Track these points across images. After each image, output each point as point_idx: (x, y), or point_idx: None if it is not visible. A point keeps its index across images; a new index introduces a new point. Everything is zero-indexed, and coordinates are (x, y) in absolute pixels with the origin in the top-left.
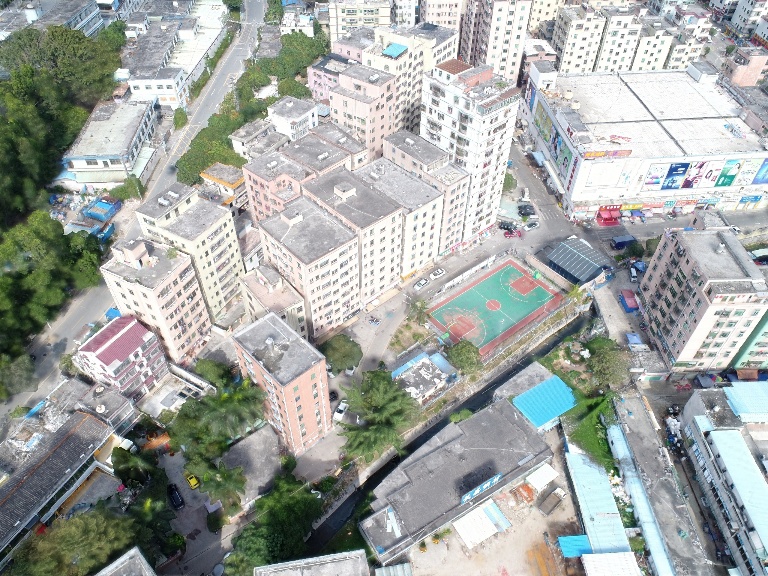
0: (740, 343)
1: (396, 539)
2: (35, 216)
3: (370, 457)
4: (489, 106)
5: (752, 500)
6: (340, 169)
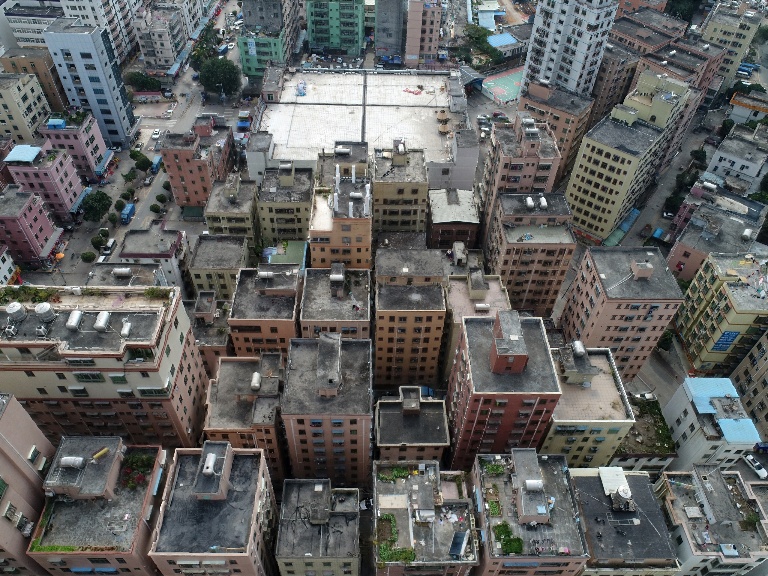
0: None
1: None
2: None
3: None
4: None
5: None
6: (655, 46)
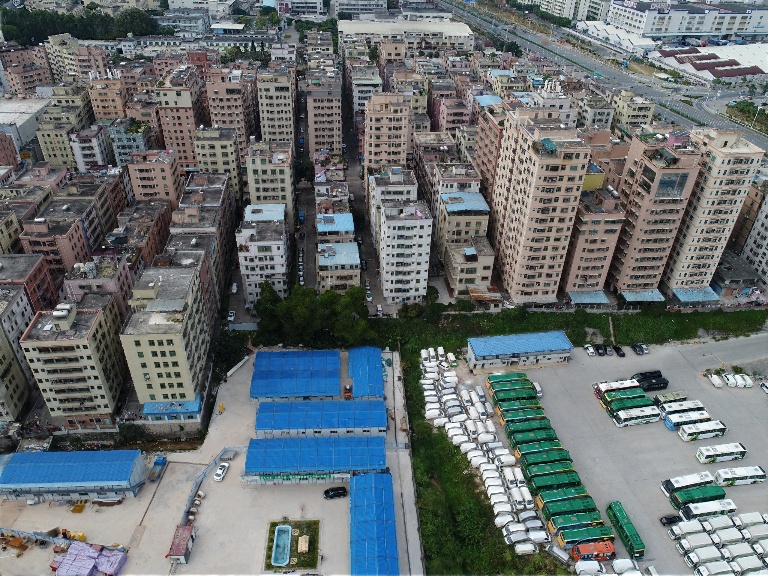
0: None
1: None
2: None
3: None
4: None
5: None
6: None
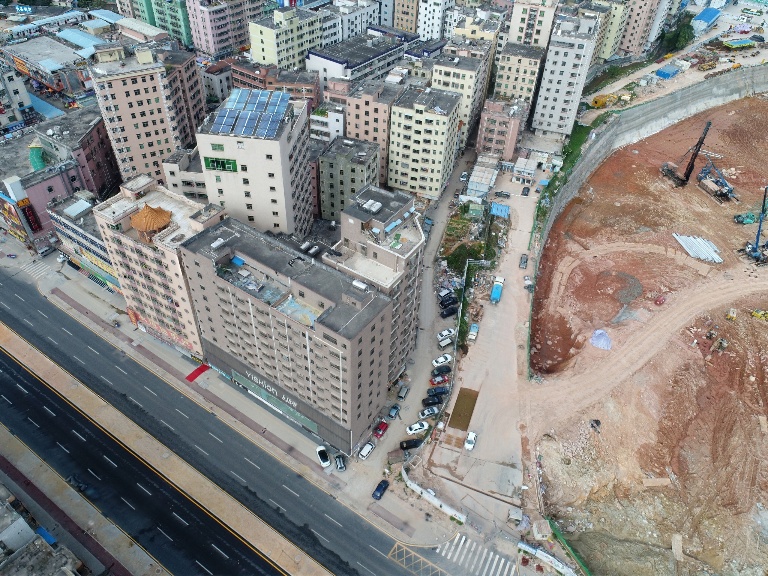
0: (130, 6)
1: None
2: None
3: (20, 1)
4: None
5: None
6: None
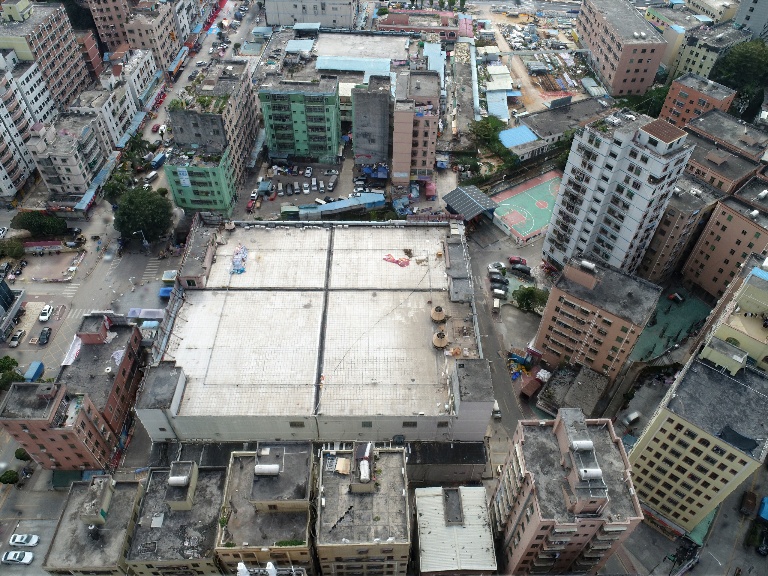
0: None
1: (600, 99)
2: None
3: None
4: (612, 109)
5: (440, 69)
6: None
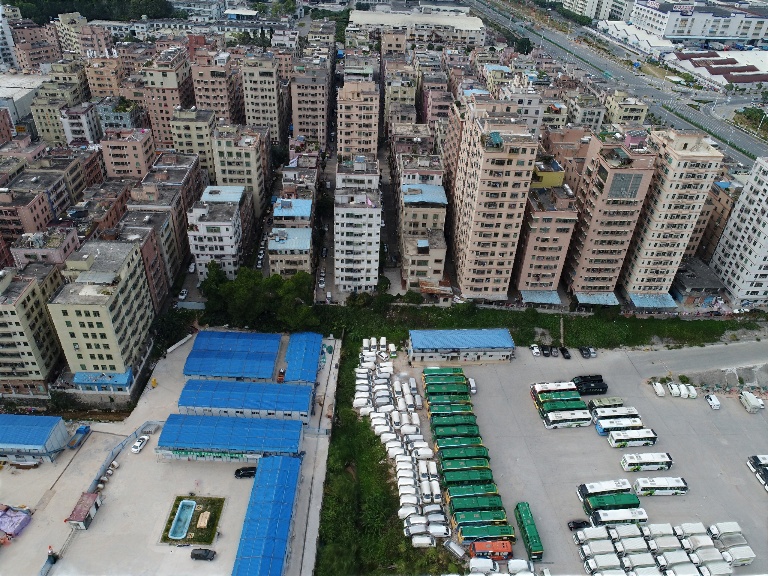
0: None
1: None
2: (30, 3)
3: None
4: None
5: None
6: None
